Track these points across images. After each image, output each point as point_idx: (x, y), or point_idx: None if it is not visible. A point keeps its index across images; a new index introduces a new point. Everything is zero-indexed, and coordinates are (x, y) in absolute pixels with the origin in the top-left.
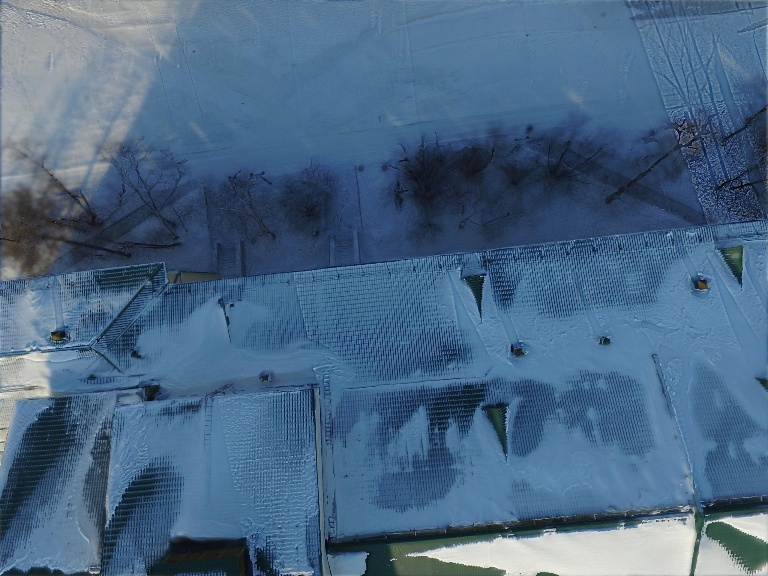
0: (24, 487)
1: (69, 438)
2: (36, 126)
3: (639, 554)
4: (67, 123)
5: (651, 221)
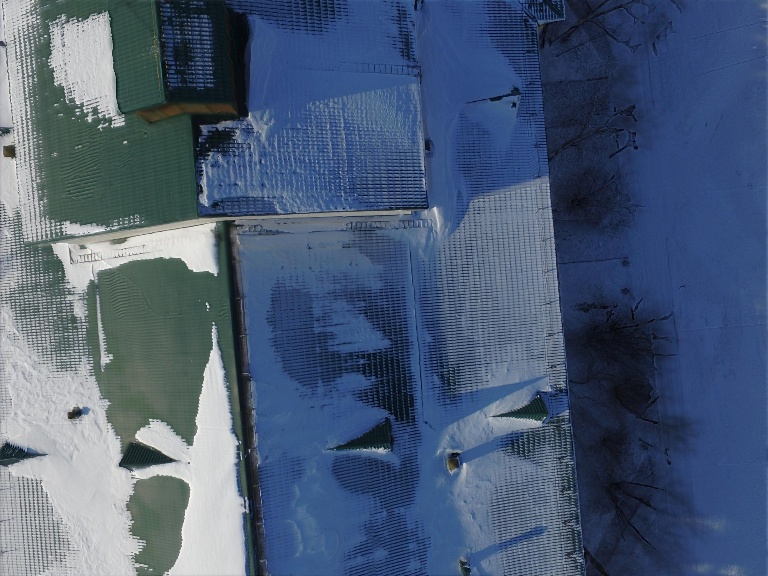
0: None
1: None
2: None
3: None
4: None
5: None
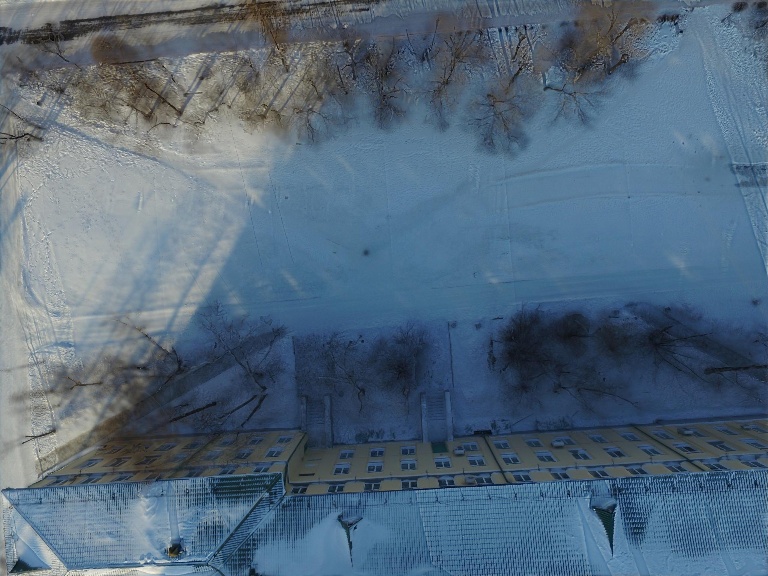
0: None
1: None
2: (122, 266)
3: None
4: (154, 265)
5: (751, 394)
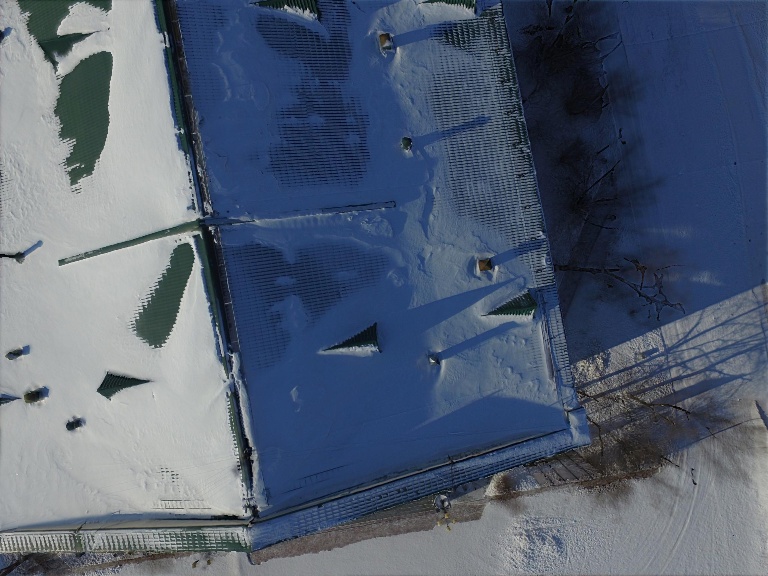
0: None
1: None
2: None
3: (145, 167)
4: None
5: None
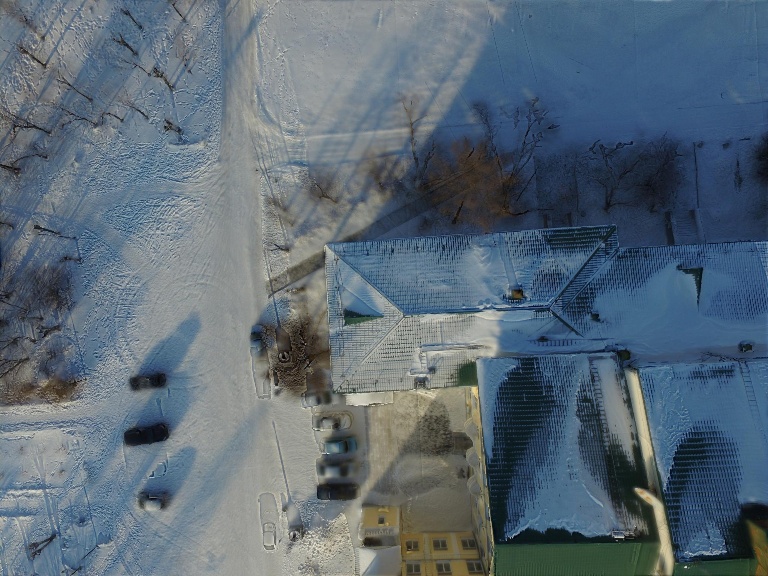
0: (514, 447)
1: (548, 399)
2: (360, 84)
3: None
4: (393, 83)
5: None
